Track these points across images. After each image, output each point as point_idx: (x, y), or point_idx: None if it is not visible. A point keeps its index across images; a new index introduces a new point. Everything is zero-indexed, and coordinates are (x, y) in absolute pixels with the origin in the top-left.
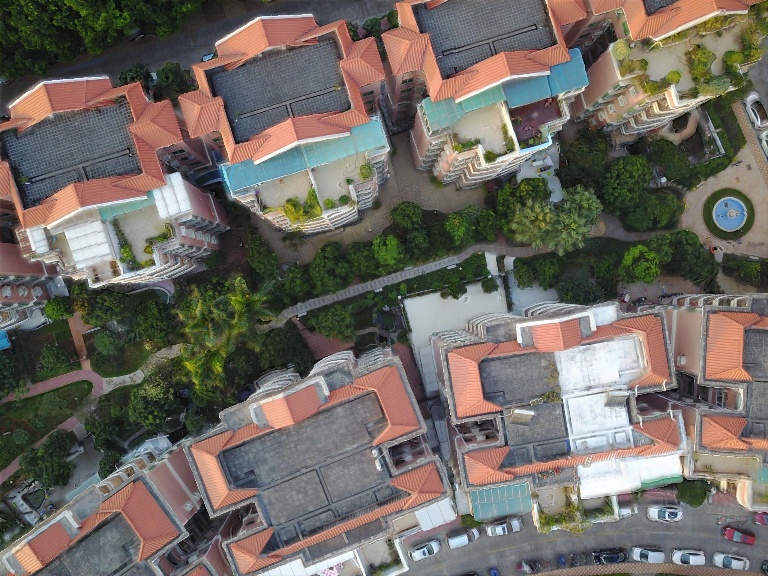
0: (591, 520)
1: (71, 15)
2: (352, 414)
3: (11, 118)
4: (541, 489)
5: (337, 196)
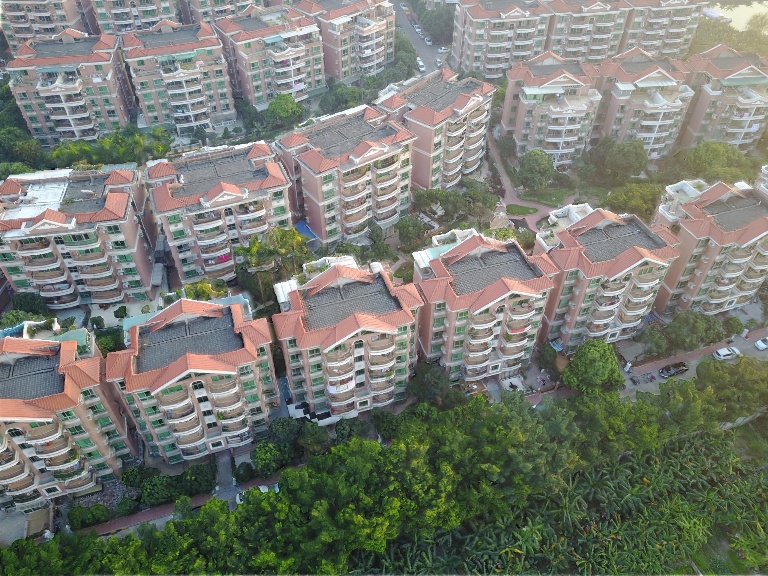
0: (73, 167)
1: None
2: (191, 195)
3: None
4: (94, 170)
5: None
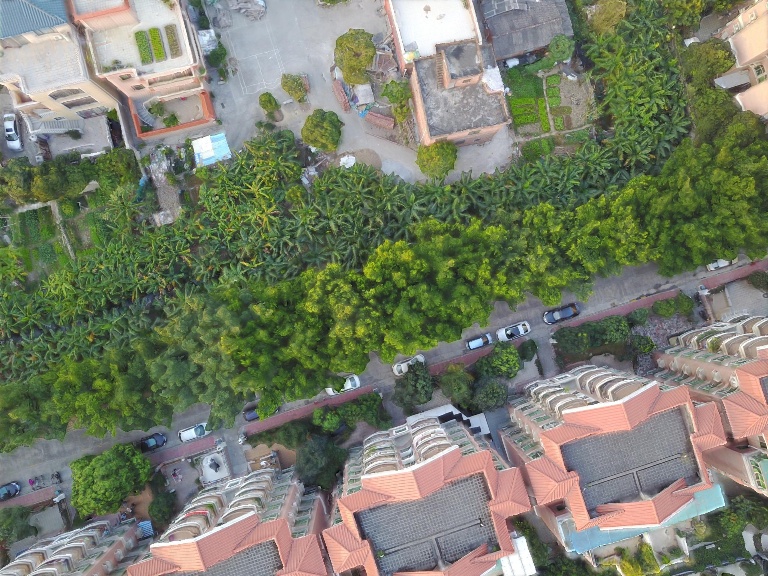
0: None
1: (377, 339)
2: None
3: (363, 488)
4: None
5: (663, 543)
